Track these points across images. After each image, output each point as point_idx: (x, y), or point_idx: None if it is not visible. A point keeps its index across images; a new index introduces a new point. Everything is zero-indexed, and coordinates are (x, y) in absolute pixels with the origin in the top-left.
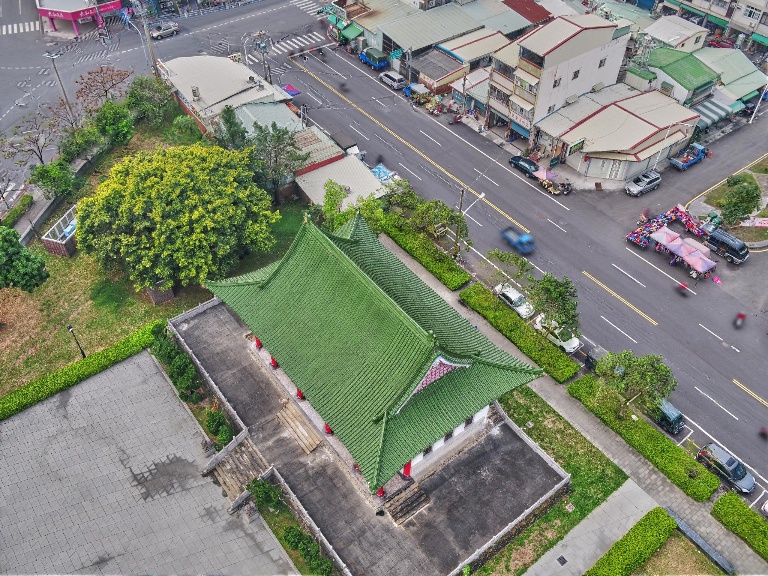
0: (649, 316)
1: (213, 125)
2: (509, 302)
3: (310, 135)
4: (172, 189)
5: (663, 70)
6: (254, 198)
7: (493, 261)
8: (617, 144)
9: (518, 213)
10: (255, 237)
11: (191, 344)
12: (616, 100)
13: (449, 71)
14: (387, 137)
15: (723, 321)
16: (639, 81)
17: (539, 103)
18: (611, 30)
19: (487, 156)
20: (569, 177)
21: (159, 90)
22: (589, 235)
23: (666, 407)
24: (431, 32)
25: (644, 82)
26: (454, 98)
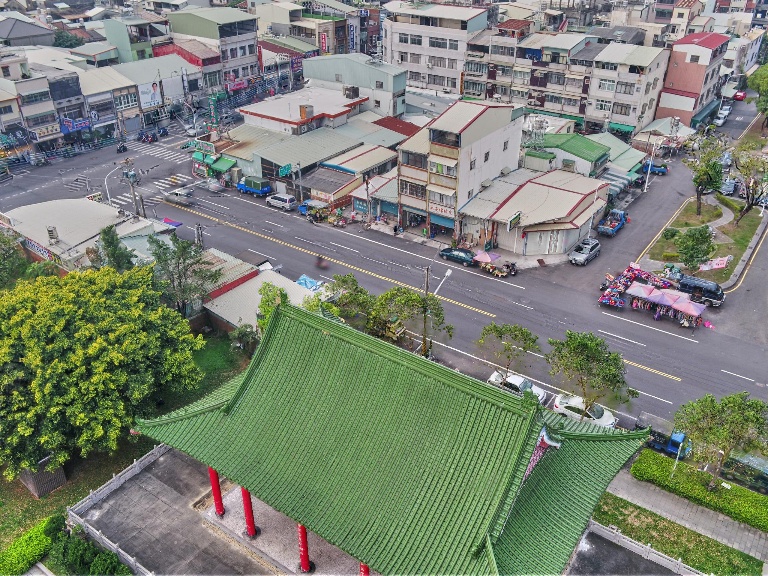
0: (667, 373)
1: (89, 253)
2: (514, 390)
3: (210, 258)
4: (53, 321)
5: (560, 148)
6: (168, 321)
7: (471, 352)
8: (552, 214)
9: (474, 300)
10: (178, 371)
11: (111, 537)
12: (527, 180)
13: (343, 183)
14: (296, 253)
15: (741, 362)
16: (540, 162)
17: (460, 187)
18: (509, 110)
19: (414, 254)
20: (508, 259)
21: (1, 240)
22: (559, 308)
23: (756, 462)
24: (312, 152)
25: (545, 162)
26: (355, 209)
